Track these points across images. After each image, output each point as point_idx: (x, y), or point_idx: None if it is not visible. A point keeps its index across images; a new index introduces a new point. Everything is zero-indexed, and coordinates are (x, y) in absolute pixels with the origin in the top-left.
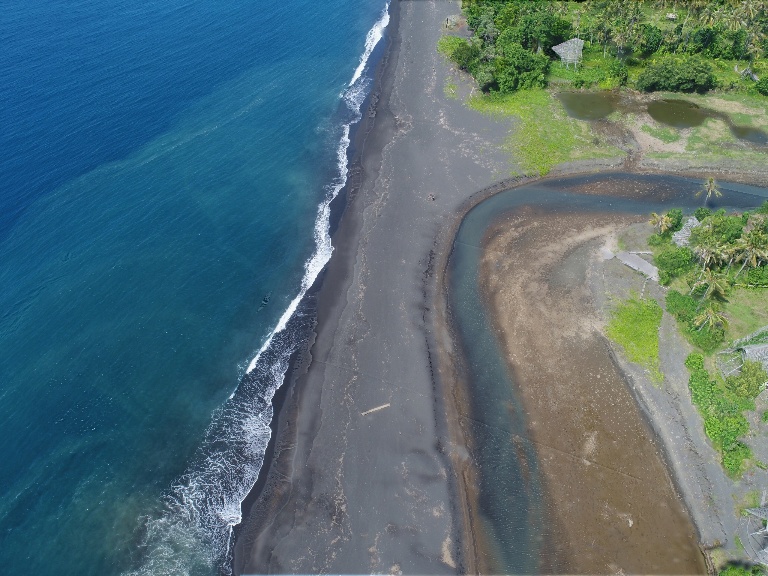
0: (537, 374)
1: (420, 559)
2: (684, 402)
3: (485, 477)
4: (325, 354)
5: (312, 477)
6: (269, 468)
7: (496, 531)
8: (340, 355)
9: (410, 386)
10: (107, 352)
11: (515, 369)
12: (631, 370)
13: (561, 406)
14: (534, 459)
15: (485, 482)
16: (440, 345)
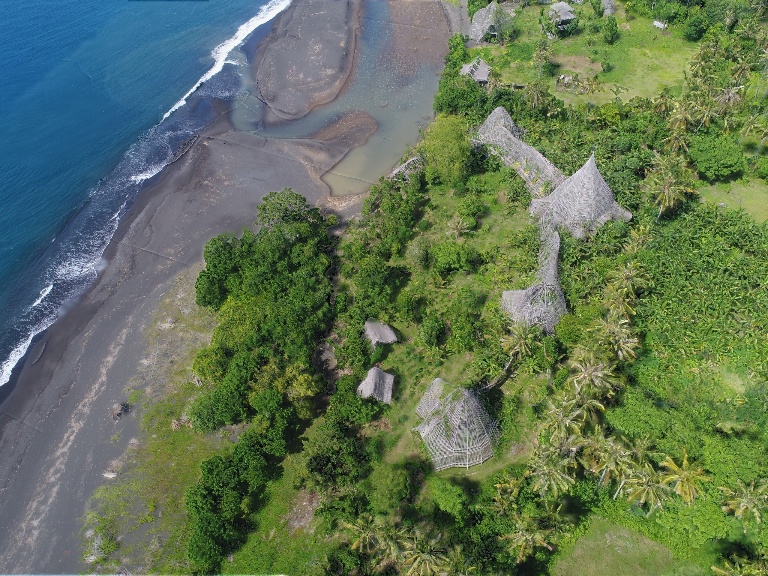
0: (400, 7)
1: (330, 44)
2: (464, 7)
3: (365, 31)
4: (297, 3)
5: (287, 31)
6: (267, 31)
7: (366, 42)
8: (304, 2)
9: (336, 7)
10: (189, 4)
11: (390, 6)
12: (446, 4)
13: (408, 14)
14: (389, 27)
15: (365, 32)
16: (355, 0)
